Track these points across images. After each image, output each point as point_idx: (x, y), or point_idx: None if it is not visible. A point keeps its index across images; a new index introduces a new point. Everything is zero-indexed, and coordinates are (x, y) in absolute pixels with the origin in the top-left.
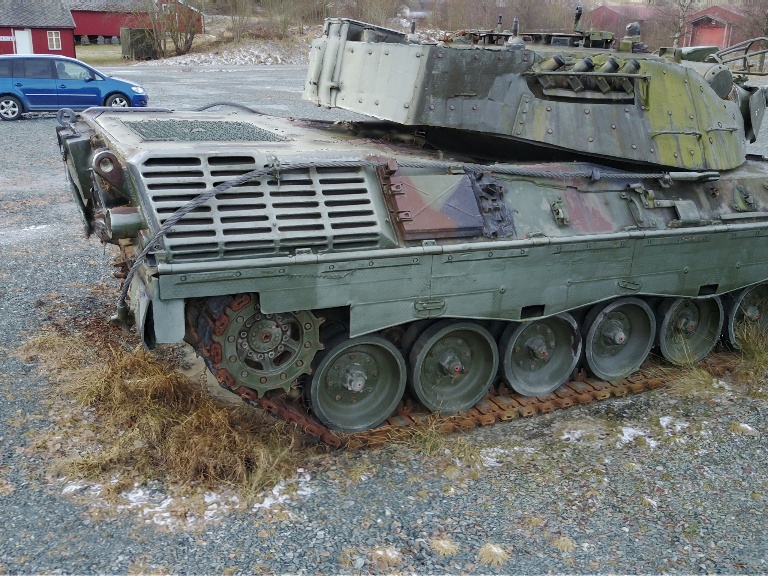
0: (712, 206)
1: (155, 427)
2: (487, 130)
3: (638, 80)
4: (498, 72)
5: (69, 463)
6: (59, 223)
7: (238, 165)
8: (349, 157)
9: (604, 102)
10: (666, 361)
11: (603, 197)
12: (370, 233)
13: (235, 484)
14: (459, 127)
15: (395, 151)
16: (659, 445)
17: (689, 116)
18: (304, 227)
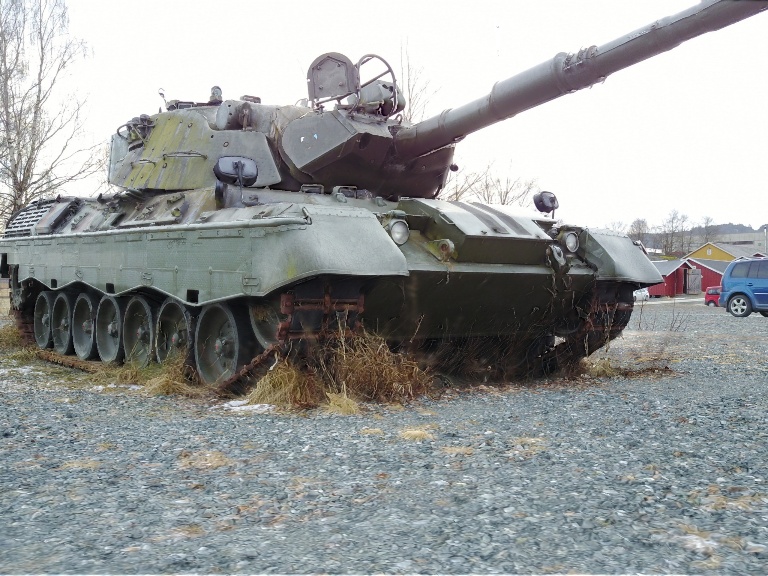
0: None
1: None
2: None
3: None
4: None
5: None
6: None
7: None
8: None
9: None
10: None
11: None
12: None
13: None
14: None
15: None
16: None
17: None
18: None
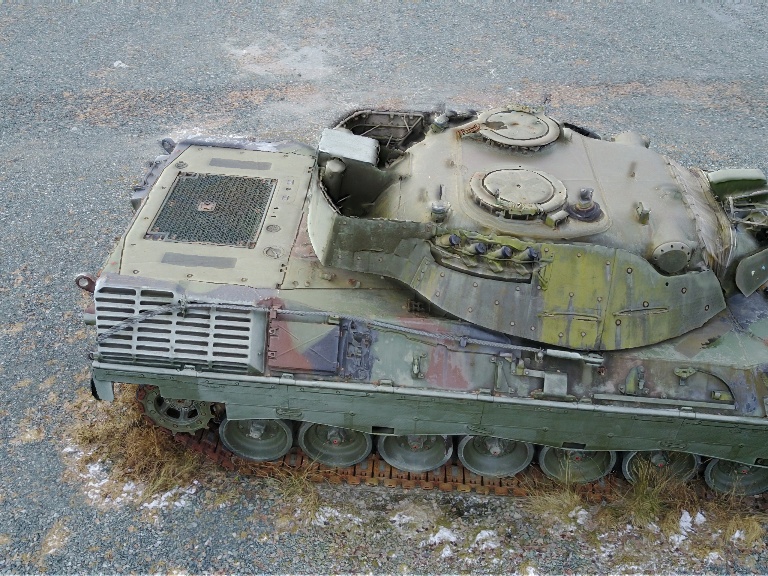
0: (594, 382)
1: (126, 423)
2: (392, 277)
3: (541, 262)
4: (404, 236)
5: (78, 429)
6: (251, 135)
7: (161, 298)
8: (244, 301)
9: (496, 278)
10: (544, 476)
11: (472, 357)
12: (241, 362)
13: (148, 481)
14: (366, 272)
15: (314, 278)
16: (448, 557)
17: (597, 298)
18: (193, 351)
